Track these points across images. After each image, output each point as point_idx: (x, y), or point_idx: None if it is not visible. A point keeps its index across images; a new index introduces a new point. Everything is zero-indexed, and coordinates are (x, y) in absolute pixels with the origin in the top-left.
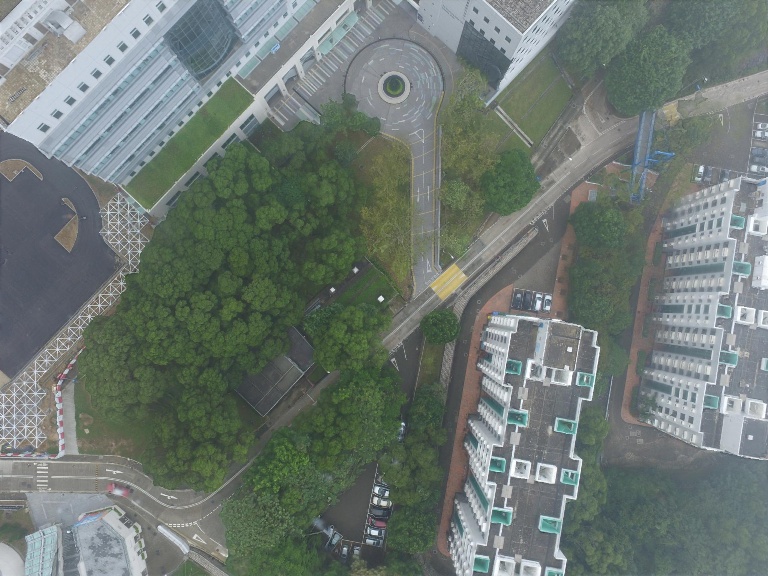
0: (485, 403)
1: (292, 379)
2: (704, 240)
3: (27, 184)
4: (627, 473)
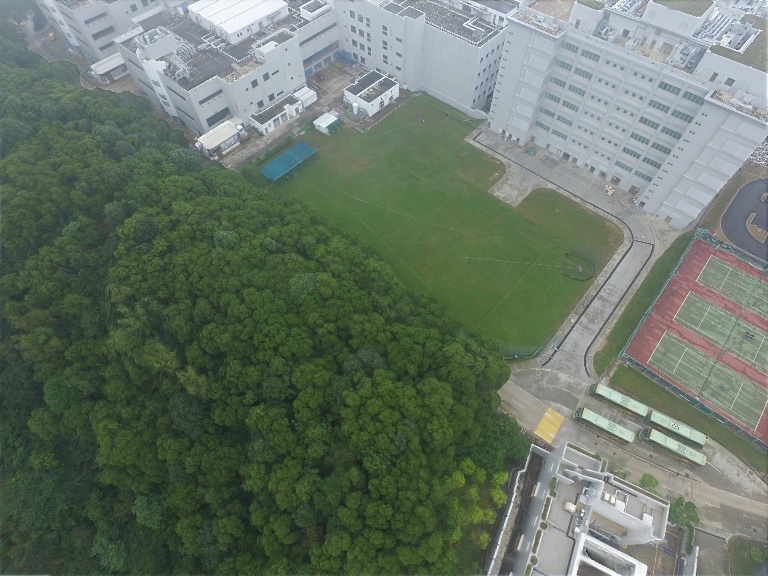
0: None
1: None
2: None
3: (764, 224)
4: None
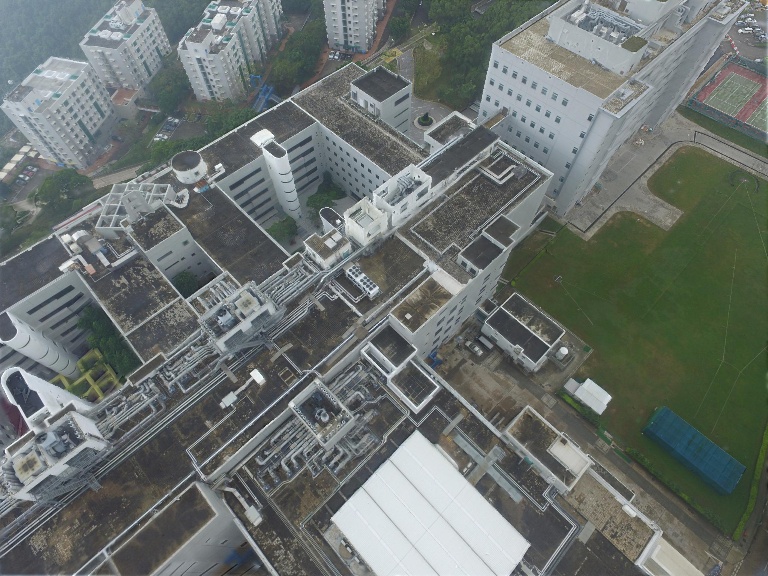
0: None
1: (482, 8)
2: None
3: None
4: (300, 4)
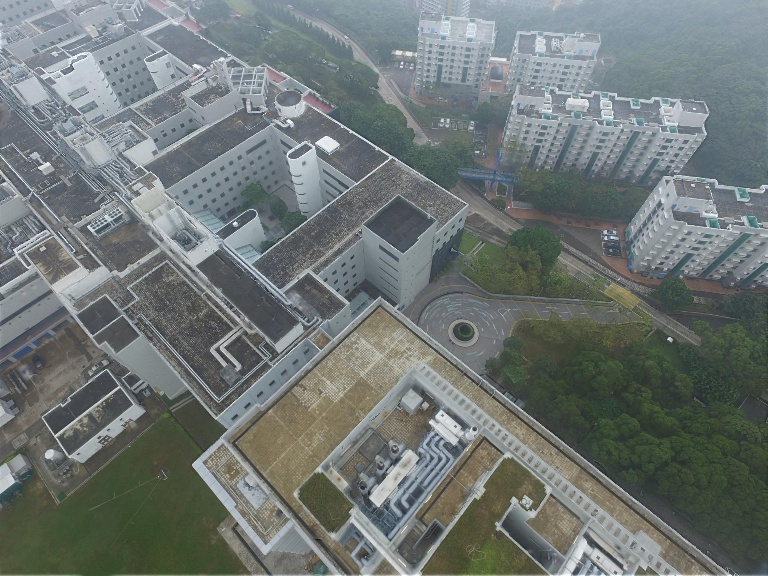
0: (717, 268)
1: None
2: (551, 138)
3: None
4: None
